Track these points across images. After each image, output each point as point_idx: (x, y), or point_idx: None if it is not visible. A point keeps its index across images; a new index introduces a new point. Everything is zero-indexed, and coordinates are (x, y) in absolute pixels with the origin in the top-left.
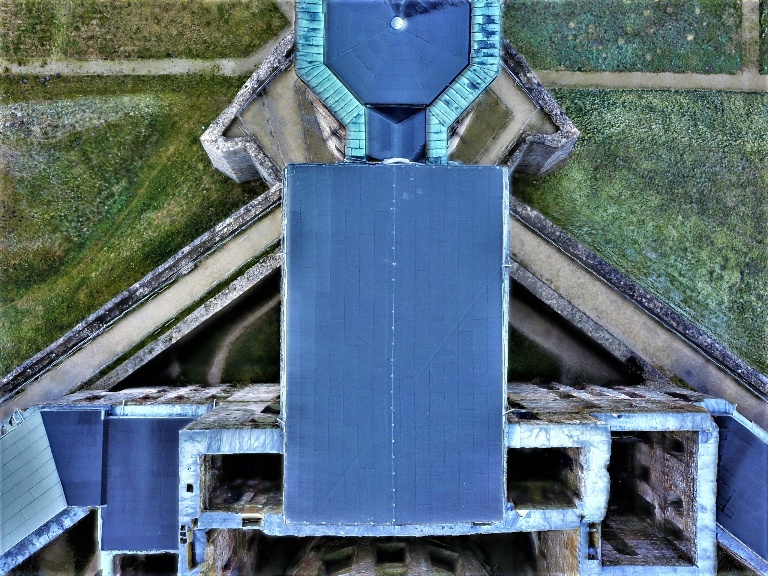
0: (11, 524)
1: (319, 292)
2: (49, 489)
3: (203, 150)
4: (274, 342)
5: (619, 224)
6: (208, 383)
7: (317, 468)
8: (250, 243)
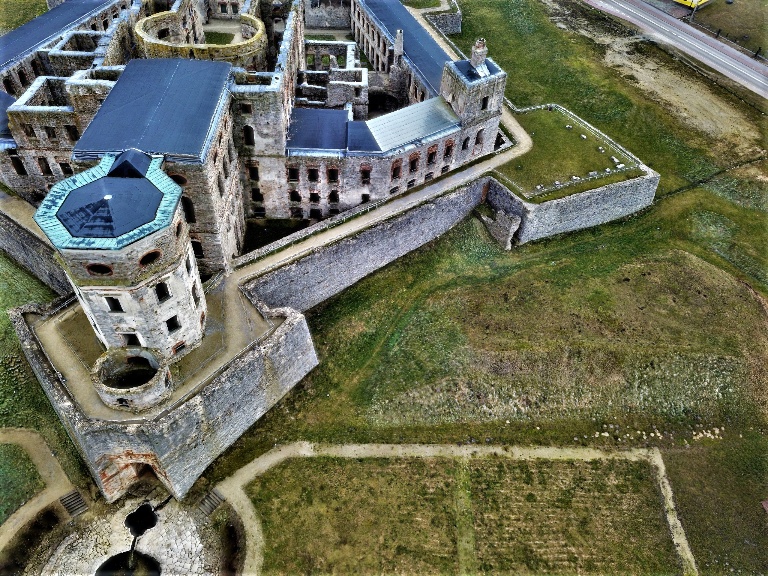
0: (394, 118)
1: (195, 116)
2: (375, 127)
3: (328, 377)
4: (273, 237)
5: (3, 304)
6: (318, 220)
7: (212, 73)
8: (275, 261)
